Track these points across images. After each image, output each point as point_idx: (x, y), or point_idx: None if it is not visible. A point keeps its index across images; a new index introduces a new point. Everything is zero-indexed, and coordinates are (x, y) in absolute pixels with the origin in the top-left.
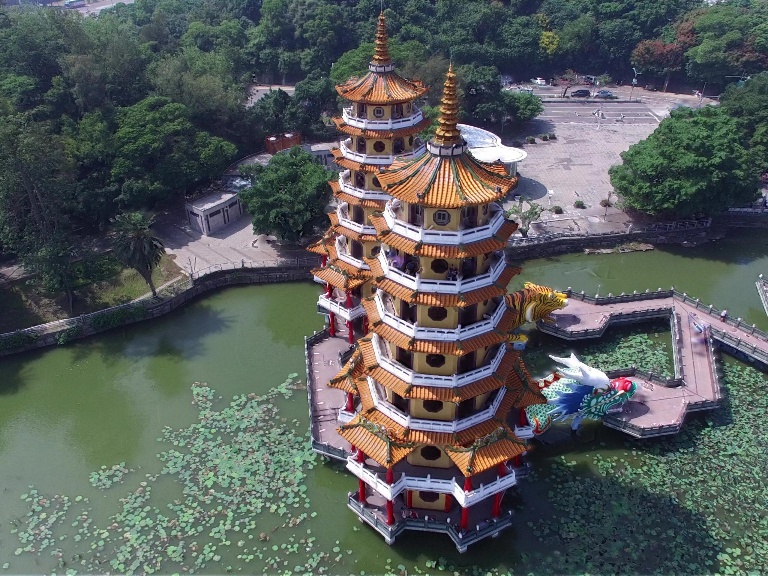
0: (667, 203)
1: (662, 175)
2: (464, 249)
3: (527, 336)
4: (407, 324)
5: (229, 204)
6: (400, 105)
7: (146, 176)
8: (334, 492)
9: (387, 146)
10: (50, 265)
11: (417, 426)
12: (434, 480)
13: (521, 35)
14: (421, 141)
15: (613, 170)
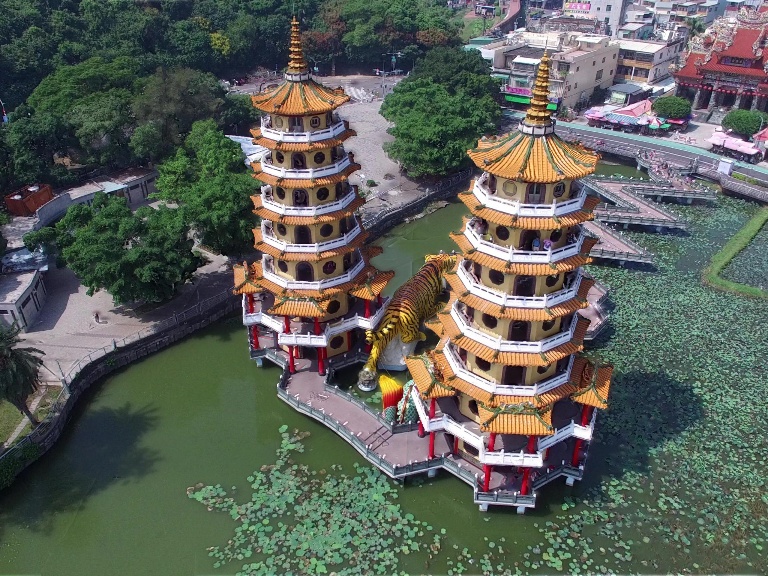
0: (454, 162)
1: (443, 139)
2: None
3: None
4: (536, 298)
5: (34, 286)
6: (330, 111)
7: None
8: (415, 509)
9: (327, 155)
10: None
11: (542, 390)
12: (559, 431)
13: (191, 40)
14: None
15: (396, 145)
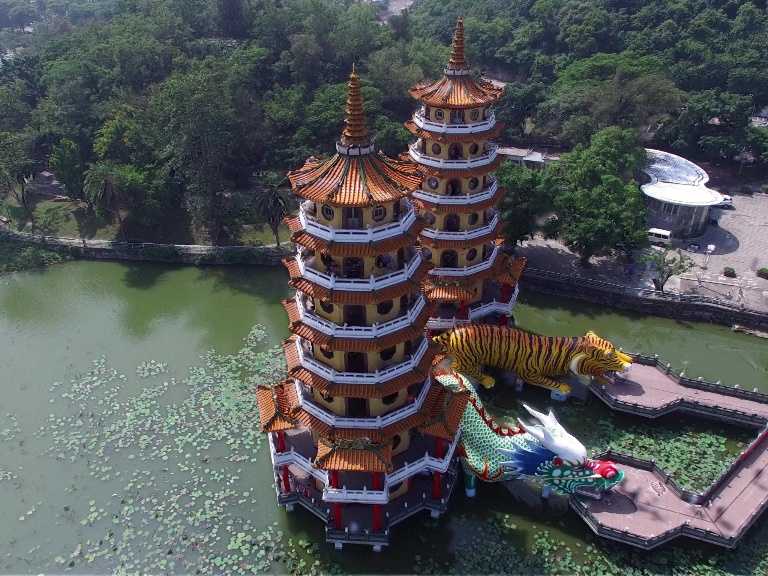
0: None
1: None
2: (331, 246)
3: (585, 391)
4: (302, 307)
5: None
6: (462, 111)
7: (319, 146)
8: None
9: (443, 149)
10: (204, 200)
11: (308, 408)
12: None
13: None
14: (487, 152)
15: None
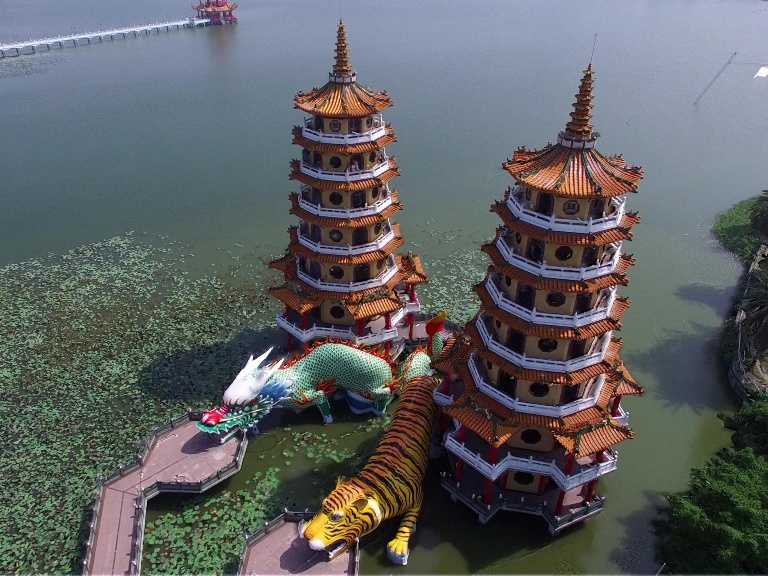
0: None
1: None
2: None
3: None
4: None
5: None
6: None
7: None
8: None
9: None
10: None
11: None
12: None
13: None
14: None
15: None
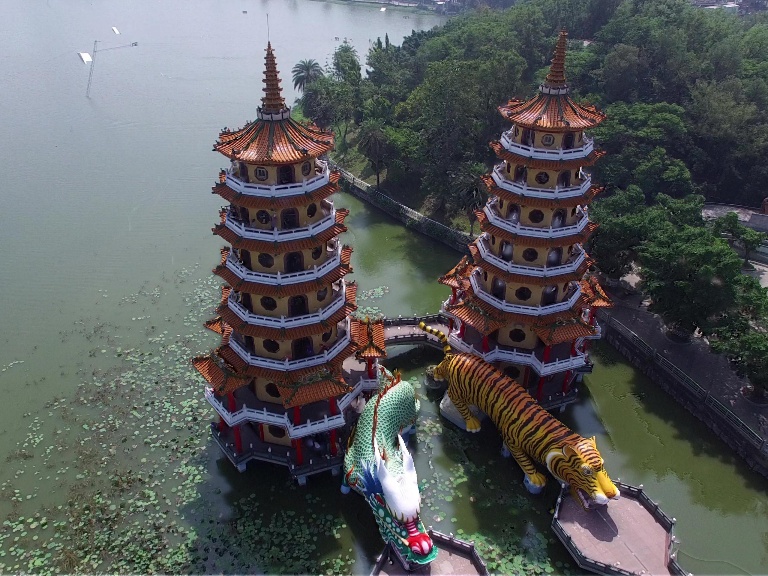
0: None
1: None
2: (221, 187)
3: None
4: None
5: None
6: (534, 132)
7: None
8: None
9: None
10: None
11: None
12: None
13: None
14: (556, 185)
15: None
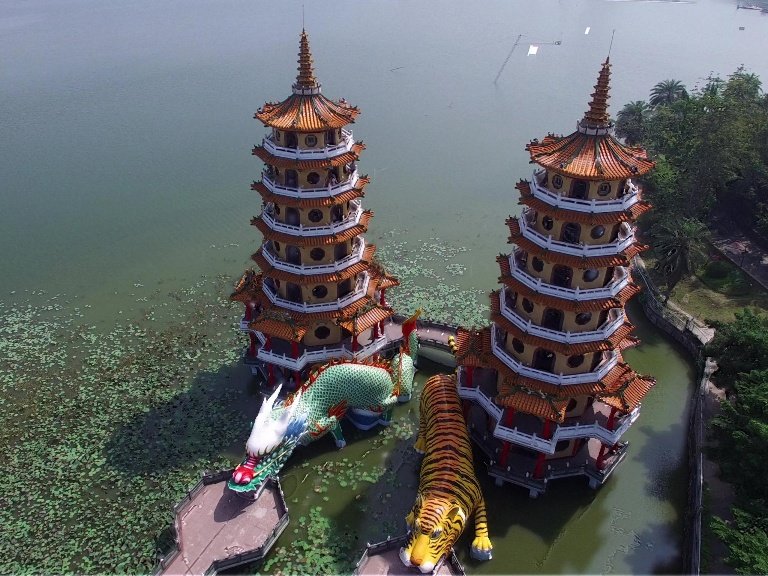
0: None
1: None
2: None
3: None
4: None
5: None
6: None
7: None
8: None
9: None
10: None
11: None
12: None
13: None
14: None
15: None
